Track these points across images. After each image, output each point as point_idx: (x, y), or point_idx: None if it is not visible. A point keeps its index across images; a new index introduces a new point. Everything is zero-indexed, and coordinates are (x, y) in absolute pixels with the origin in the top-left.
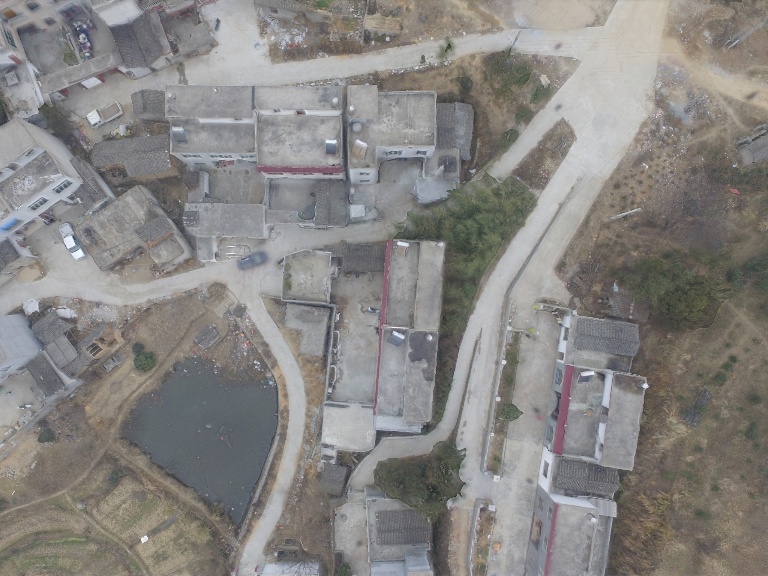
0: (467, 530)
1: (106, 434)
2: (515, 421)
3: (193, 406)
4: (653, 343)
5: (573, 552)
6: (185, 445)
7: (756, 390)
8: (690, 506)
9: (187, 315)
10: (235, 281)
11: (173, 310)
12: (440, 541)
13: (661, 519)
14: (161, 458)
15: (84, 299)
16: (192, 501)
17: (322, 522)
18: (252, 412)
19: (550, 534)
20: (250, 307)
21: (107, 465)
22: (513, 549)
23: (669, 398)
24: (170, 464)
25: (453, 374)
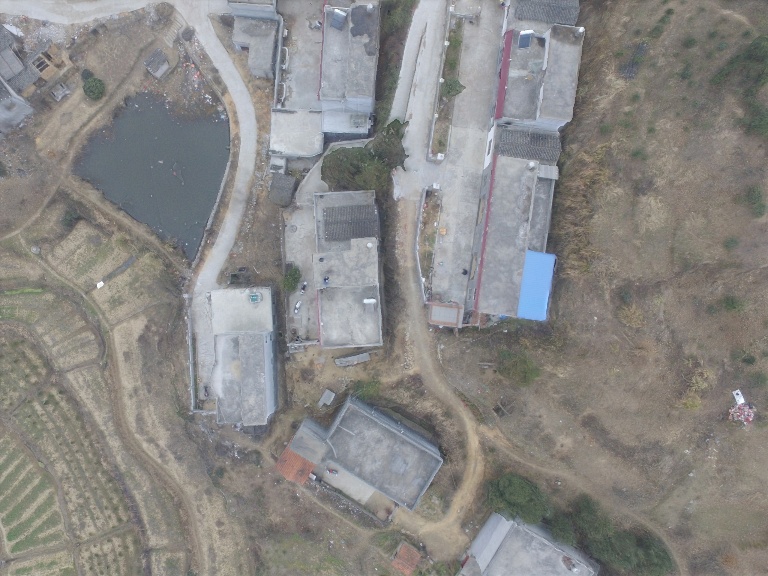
0: (414, 220)
1: (58, 169)
2: (460, 108)
3: (145, 142)
4: (595, 22)
5: (513, 203)
6: (138, 182)
7: (693, 36)
8: (628, 150)
9: (136, 42)
10: (183, 2)
11: (122, 36)
12: (388, 233)
13: (600, 165)
14: (114, 194)
15: (30, 17)
16: (145, 234)
17: (274, 241)
18: (205, 151)
19: (490, 185)
20: (199, 30)
21: (60, 205)
22: (460, 236)
23: (609, 58)
24: (123, 199)
25: (399, 72)
